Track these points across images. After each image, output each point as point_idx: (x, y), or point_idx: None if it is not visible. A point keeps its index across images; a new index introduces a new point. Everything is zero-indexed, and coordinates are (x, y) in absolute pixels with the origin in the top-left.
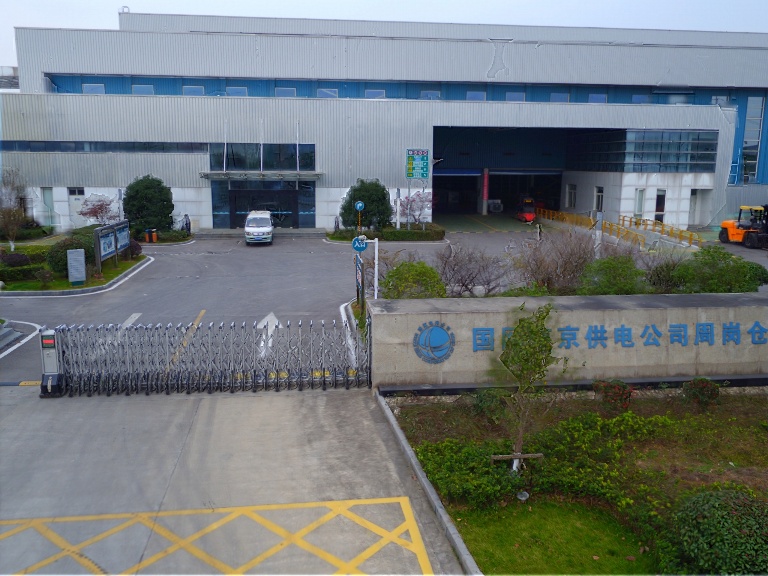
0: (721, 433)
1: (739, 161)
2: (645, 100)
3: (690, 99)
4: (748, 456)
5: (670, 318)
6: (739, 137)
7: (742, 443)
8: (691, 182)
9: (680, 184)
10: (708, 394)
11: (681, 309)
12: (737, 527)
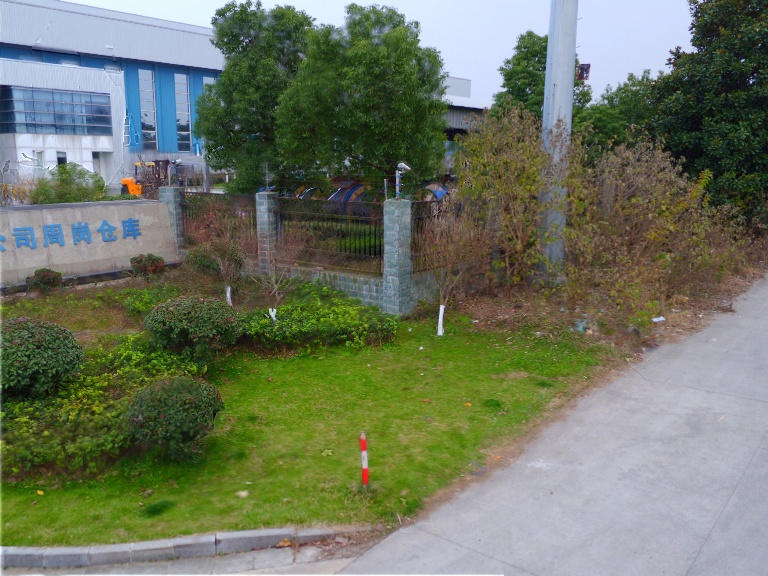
0: (58, 310)
1: (130, 122)
2: (27, 56)
3: (76, 60)
4: (83, 323)
5: (12, 221)
6: (126, 99)
7: (79, 315)
8: (91, 145)
9: (80, 146)
10: (50, 282)
11: (23, 212)
12: (9, 340)
